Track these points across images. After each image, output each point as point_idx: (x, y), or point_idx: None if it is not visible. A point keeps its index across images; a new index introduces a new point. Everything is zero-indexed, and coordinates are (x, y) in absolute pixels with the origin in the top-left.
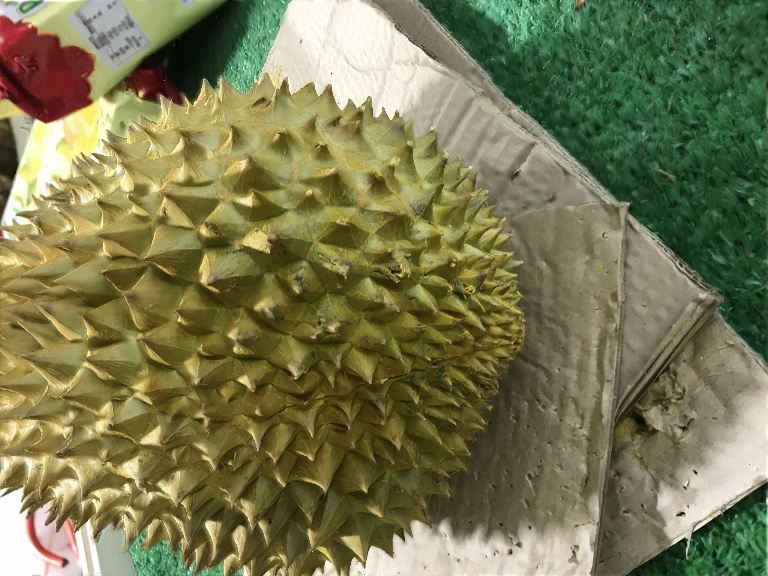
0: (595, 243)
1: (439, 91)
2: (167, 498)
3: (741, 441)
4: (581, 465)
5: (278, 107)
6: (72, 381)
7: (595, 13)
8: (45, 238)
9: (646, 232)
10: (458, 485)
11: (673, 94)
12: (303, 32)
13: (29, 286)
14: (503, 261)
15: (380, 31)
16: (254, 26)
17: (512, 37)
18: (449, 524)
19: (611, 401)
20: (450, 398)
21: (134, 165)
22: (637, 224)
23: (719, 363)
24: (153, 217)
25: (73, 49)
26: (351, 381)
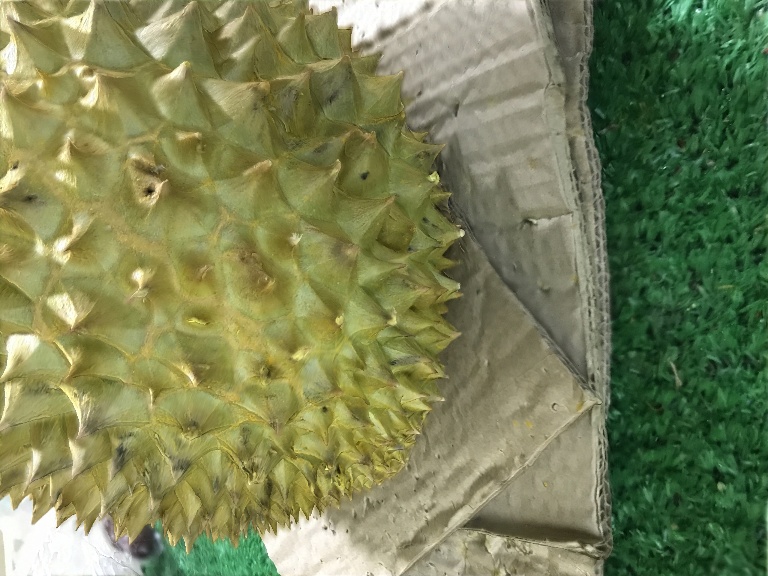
0: (541, 403)
1: (510, 29)
2: None
3: None
4: (411, 532)
5: (160, 209)
6: None
7: None
8: None
9: (599, 429)
10: None
11: (760, 303)
12: None
13: None
14: (415, 411)
15: None
16: None
17: None
18: None
19: (463, 520)
20: None
21: None
22: (597, 413)
23: (569, 574)
24: None
25: None
26: None
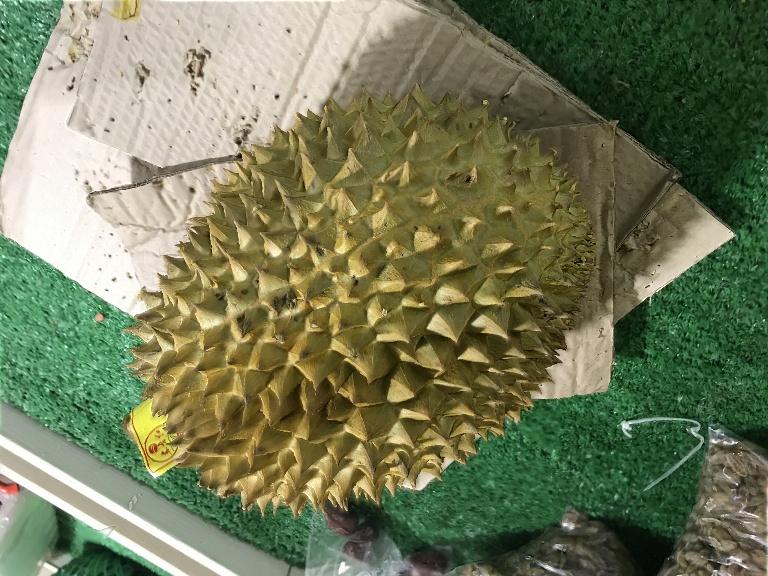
0: (597, 152)
1: (420, 28)
2: None
3: (688, 245)
4: (597, 285)
5: (480, 181)
6: (392, 431)
7: None
8: (311, 351)
9: (625, 135)
10: None
11: (625, 22)
12: None
13: (291, 386)
14: None
15: None
16: None
17: None
18: None
19: (613, 245)
20: (578, 304)
21: (410, 278)
22: (618, 130)
23: (673, 206)
24: (431, 306)
25: None
26: (546, 330)
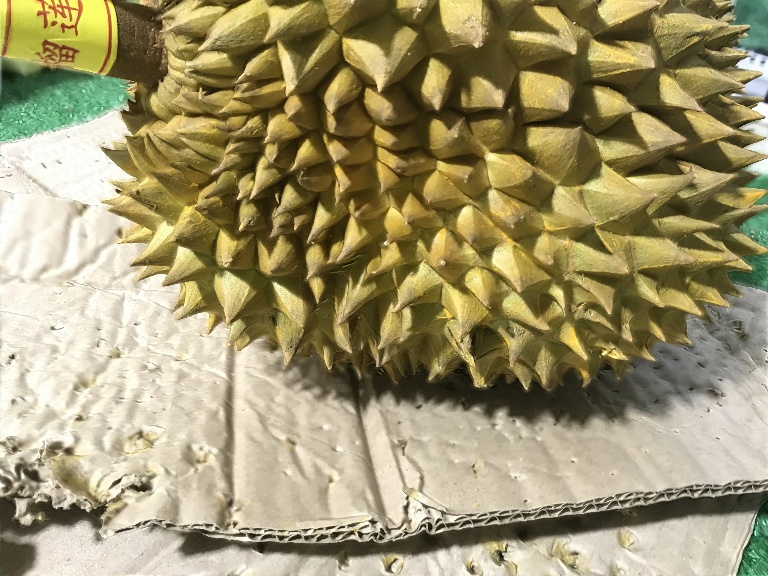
0: None
1: None
2: None
3: None
4: (713, 339)
5: None
6: None
7: None
8: None
9: None
10: None
11: None
12: None
13: None
14: None
15: None
16: (53, 101)
17: None
18: (636, 408)
19: None
20: None
21: None
22: None
23: None
24: None
25: None
26: None
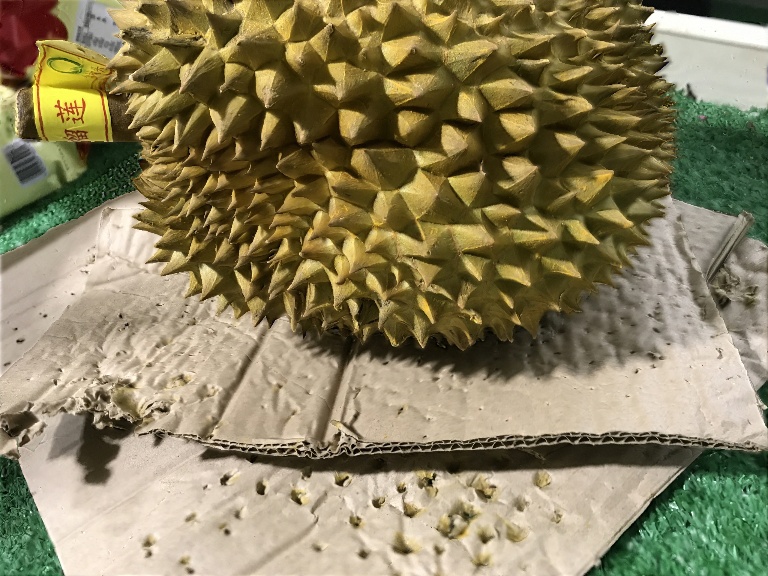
0: None
1: None
2: (511, 51)
3: None
4: (693, 305)
5: None
6: None
7: None
8: None
9: None
10: (564, 341)
11: None
12: None
13: None
14: None
15: None
16: None
17: None
18: (566, 368)
19: (700, 269)
20: None
21: None
22: None
23: (760, 258)
24: None
25: (57, 22)
26: None
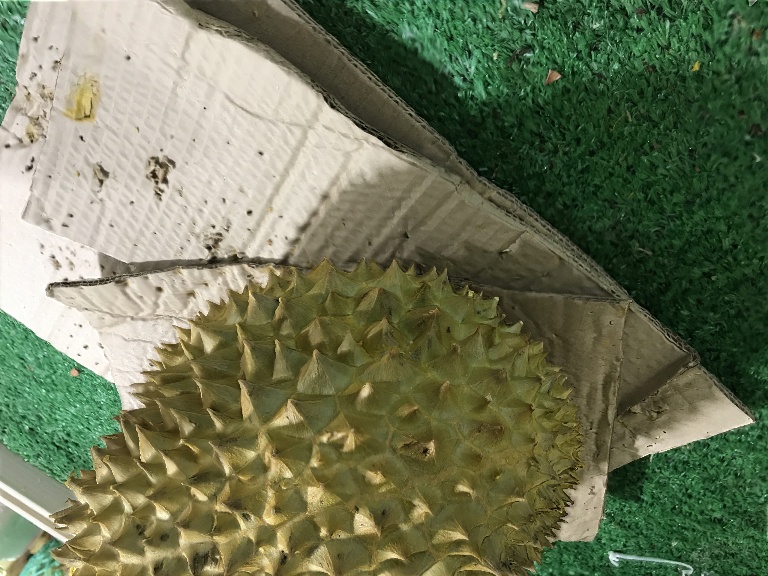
0: (603, 328)
1: (407, 179)
2: None
3: (700, 422)
4: (592, 447)
5: (439, 454)
6: None
7: (569, 93)
8: None
9: (639, 311)
10: None
11: (654, 190)
12: (131, 50)
13: None
14: None
15: (295, 93)
16: None
17: (464, 92)
18: None
19: (614, 414)
20: None
21: (343, 573)
22: (631, 305)
23: (687, 382)
24: None
25: None
26: None
